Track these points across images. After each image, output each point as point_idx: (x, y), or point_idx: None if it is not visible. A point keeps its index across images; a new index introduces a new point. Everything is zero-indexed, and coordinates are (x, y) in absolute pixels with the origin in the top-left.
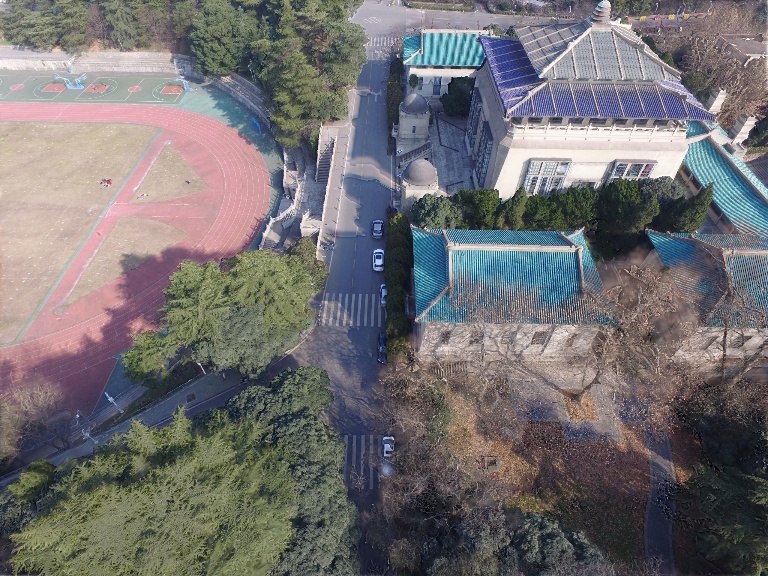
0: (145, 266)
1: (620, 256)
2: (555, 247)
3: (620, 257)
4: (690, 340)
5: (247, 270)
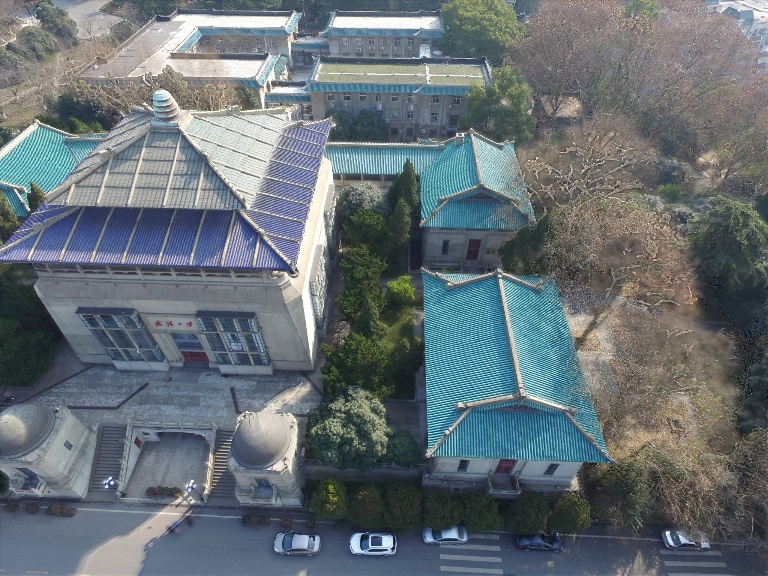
0: None
1: (402, 262)
2: None
3: (403, 263)
4: None
5: None
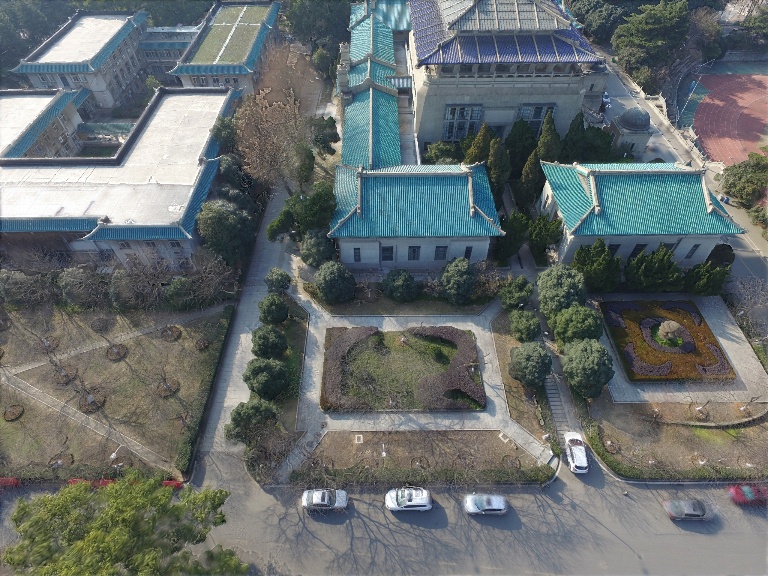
0: (759, 128)
1: None
2: None
3: None
4: None
5: (654, 6)
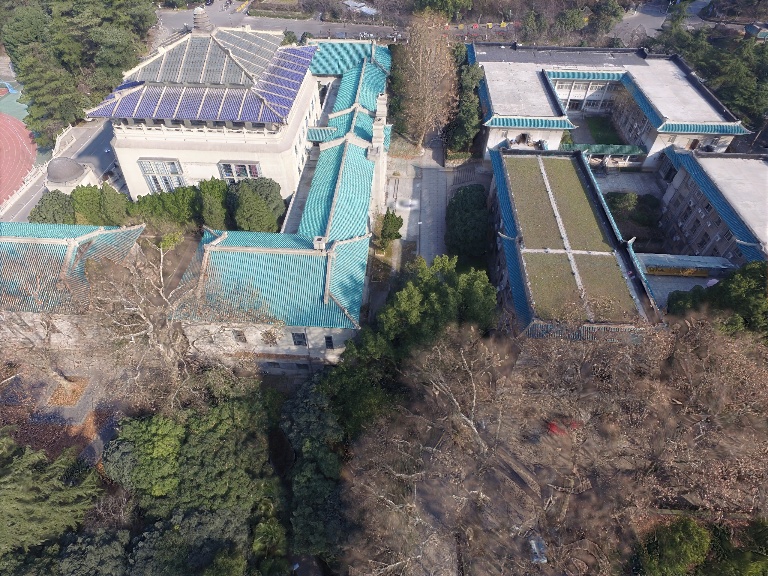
0: None
1: None
2: (47, 239)
3: None
4: (188, 333)
5: None
